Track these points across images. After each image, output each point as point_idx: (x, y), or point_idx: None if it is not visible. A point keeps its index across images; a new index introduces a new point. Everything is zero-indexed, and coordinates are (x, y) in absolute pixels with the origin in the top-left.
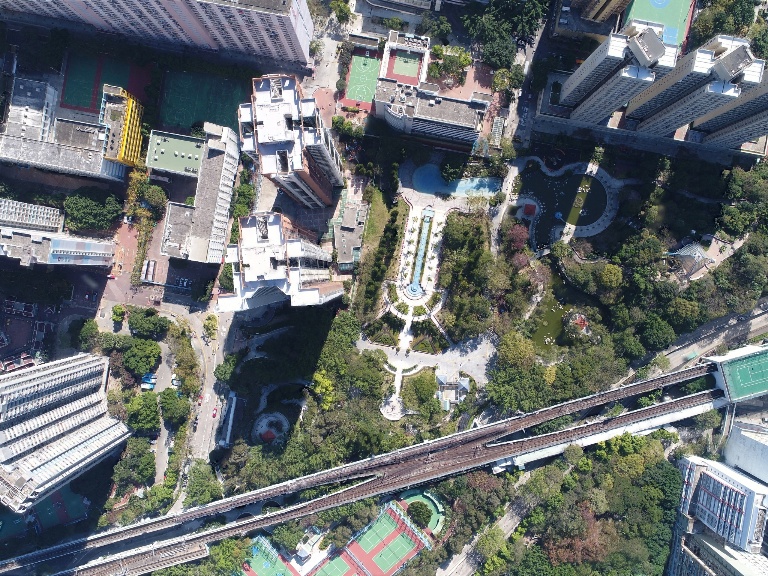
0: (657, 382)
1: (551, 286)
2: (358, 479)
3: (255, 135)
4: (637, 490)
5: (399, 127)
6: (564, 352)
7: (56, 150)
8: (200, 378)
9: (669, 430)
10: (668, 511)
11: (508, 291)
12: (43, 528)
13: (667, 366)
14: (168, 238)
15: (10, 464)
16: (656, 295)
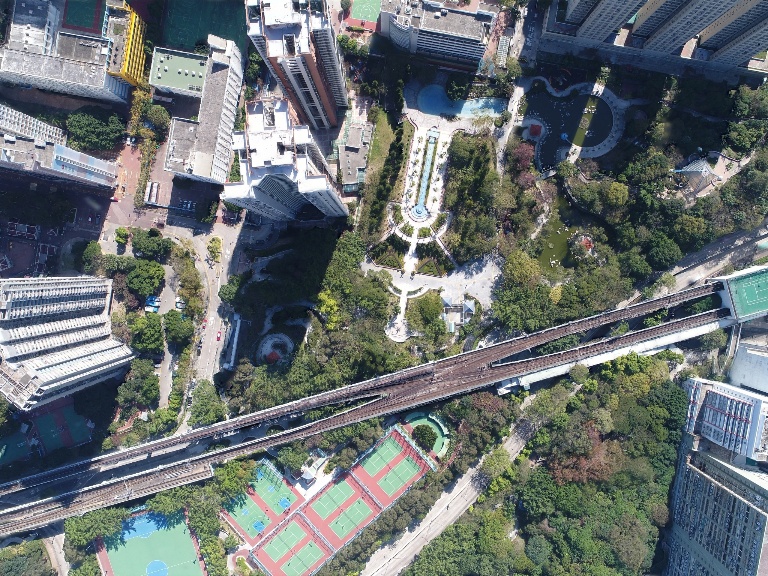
0: (663, 301)
1: (557, 208)
2: (363, 400)
3: (262, 17)
4: (643, 409)
5: (404, 44)
6: (570, 273)
7: (59, 64)
8: (204, 301)
9: (675, 351)
10: (673, 431)
11: (514, 212)
12: (47, 452)
13: (673, 284)
14: (172, 153)
15: (15, 363)
16: (662, 213)
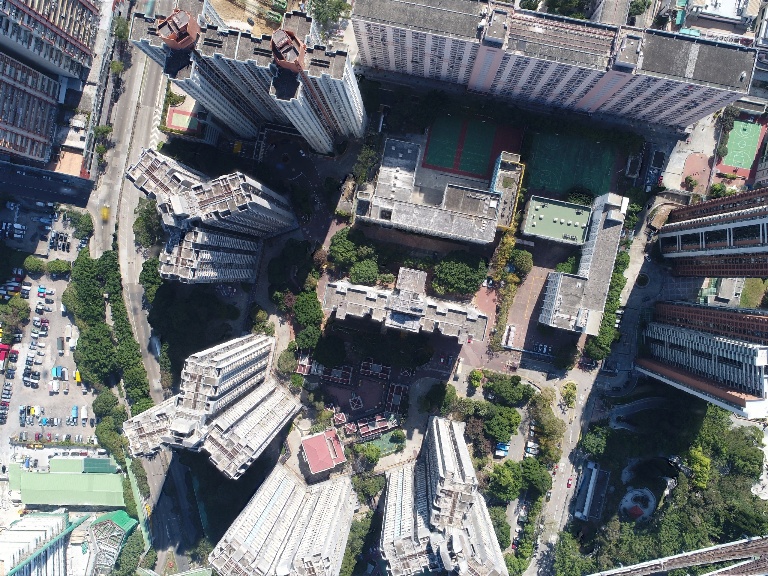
0: None
1: None
2: (730, 560)
3: None
4: None
5: None
6: None
7: (449, 217)
8: None
9: None
10: None
11: None
12: None
13: None
14: (559, 309)
15: None
16: None
